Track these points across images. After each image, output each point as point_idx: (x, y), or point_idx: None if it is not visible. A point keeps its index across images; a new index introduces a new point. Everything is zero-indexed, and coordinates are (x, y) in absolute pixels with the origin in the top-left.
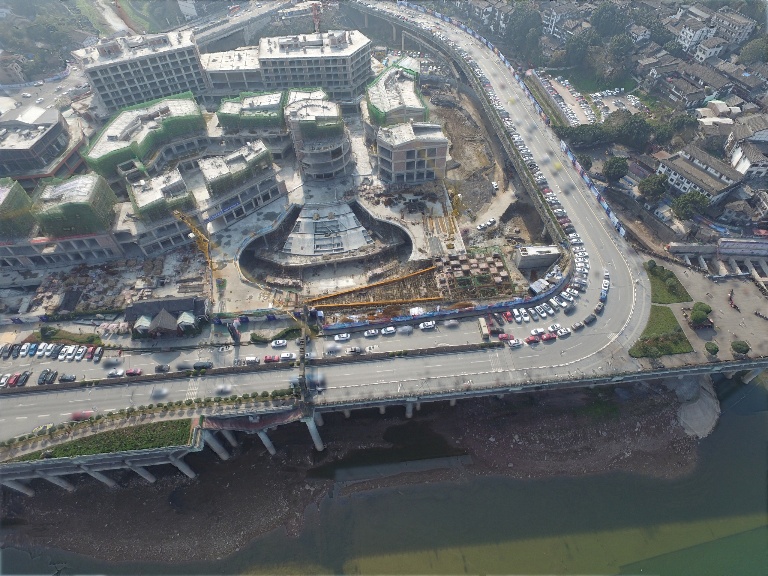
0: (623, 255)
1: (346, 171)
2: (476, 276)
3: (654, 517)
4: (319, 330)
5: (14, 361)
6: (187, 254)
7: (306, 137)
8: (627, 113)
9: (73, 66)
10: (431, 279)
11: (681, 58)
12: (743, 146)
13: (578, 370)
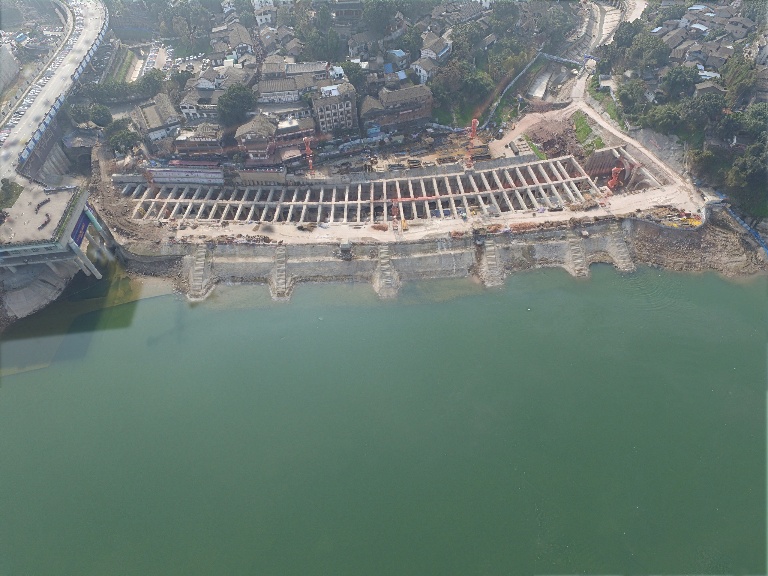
0: (1, 177)
1: None
2: None
3: None
4: None
5: None
6: None
7: None
8: None
9: None
10: None
11: (256, 26)
12: (188, 93)
13: None
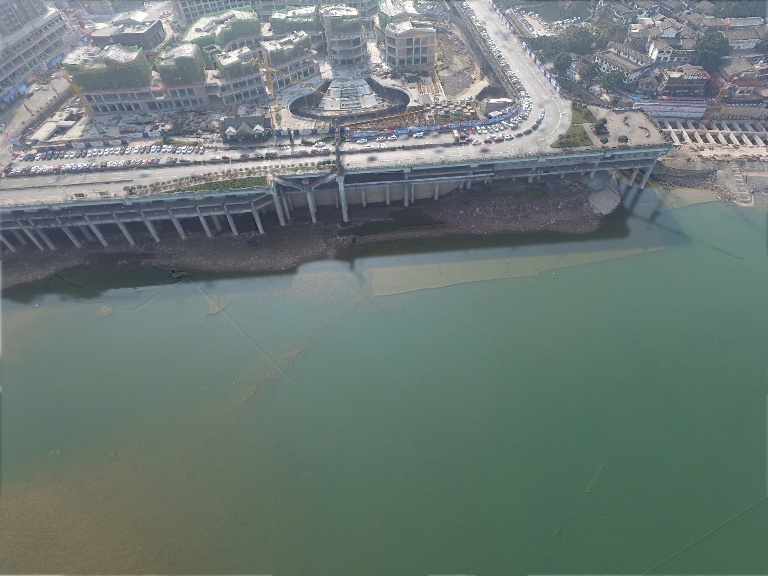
0: (556, 102)
1: (363, 61)
2: (453, 113)
3: (565, 250)
4: (346, 138)
5: (147, 154)
6: (253, 105)
7: (335, 30)
8: (576, 27)
9: (149, 4)
10: (422, 117)
11: None
12: (655, 41)
13: (516, 154)
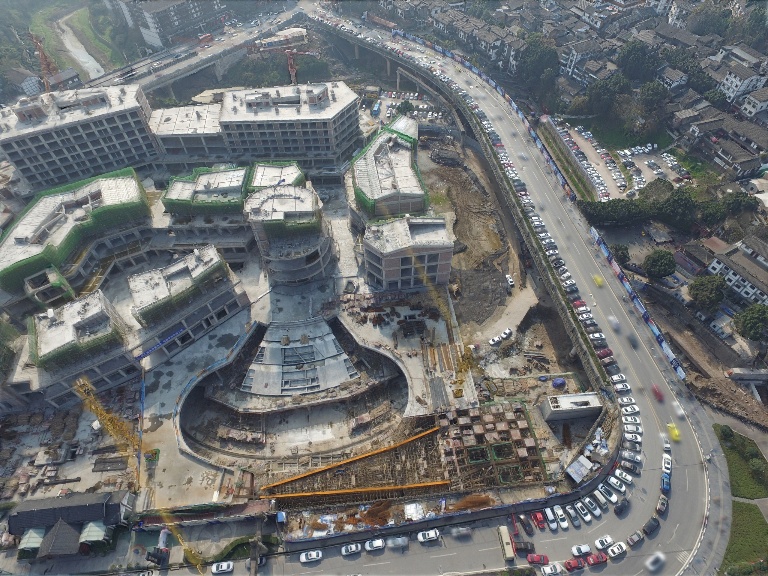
0: (685, 411)
1: (325, 271)
2: (493, 445)
3: None
4: (279, 543)
5: None
6: (112, 404)
7: (272, 237)
8: (668, 185)
9: None
10: (433, 445)
11: (724, 109)
12: None
13: None
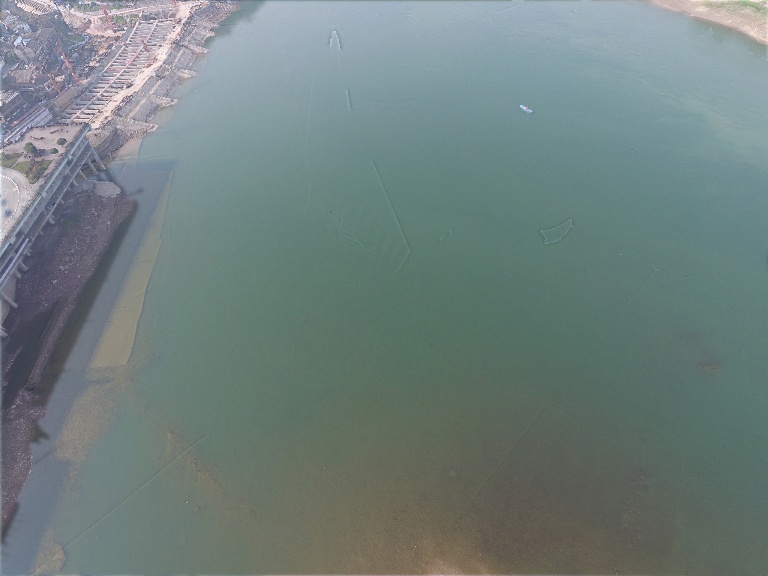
0: None
1: None
2: None
3: (145, 221)
4: None
5: None
6: None
7: None
8: None
9: None
10: None
11: None
12: None
13: (23, 207)
